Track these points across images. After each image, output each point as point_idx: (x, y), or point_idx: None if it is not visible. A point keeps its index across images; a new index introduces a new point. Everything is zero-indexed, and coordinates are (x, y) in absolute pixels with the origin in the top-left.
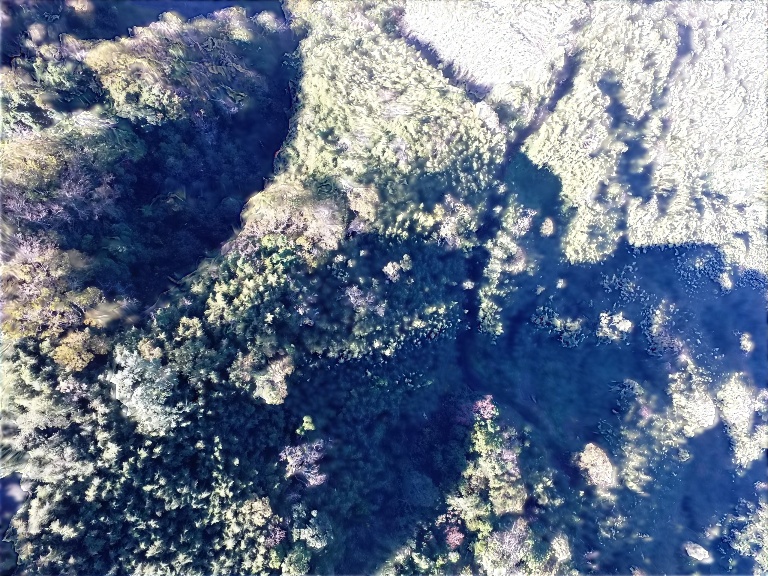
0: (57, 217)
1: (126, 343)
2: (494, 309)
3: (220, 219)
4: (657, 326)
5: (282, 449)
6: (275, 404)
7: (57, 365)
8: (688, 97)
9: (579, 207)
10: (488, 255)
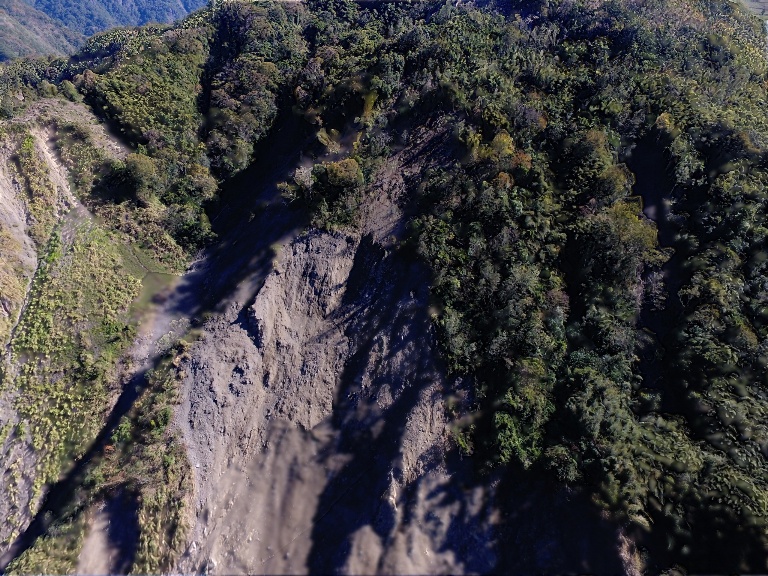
0: None
1: None
2: None
3: None
4: None
5: None
6: None
7: None
8: None
9: None
10: None
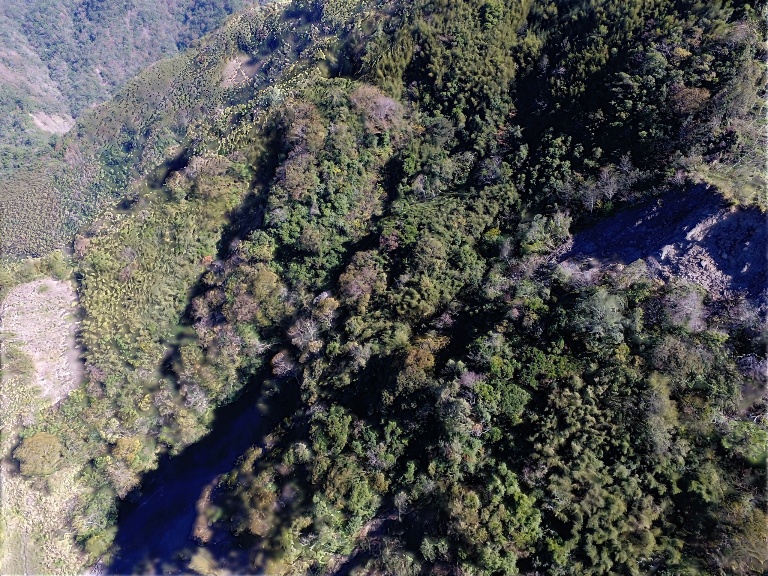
0: None
1: None
2: None
3: (248, 203)
4: None
5: None
6: None
7: None
8: None
9: None
10: None
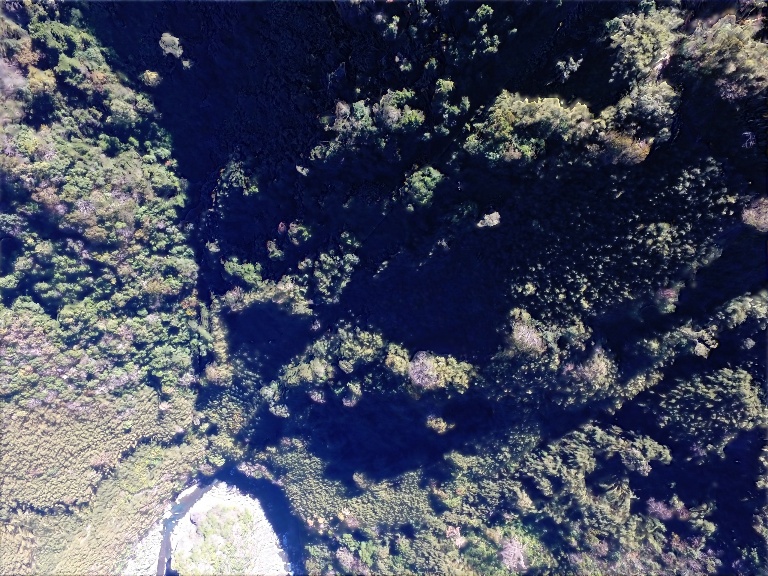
0: None
1: None
2: None
3: None
4: (598, 376)
5: None
6: None
7: None
8: (684, 567)
9: None
10: None
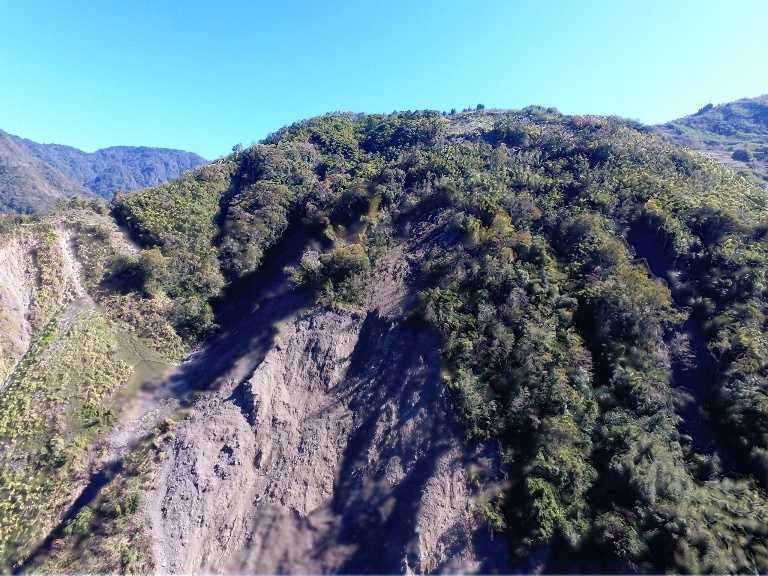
0: None
1: None
2: None
3: (235, 187)
4: None
5: None
6: None
7: None
8: None
9: None
10: None
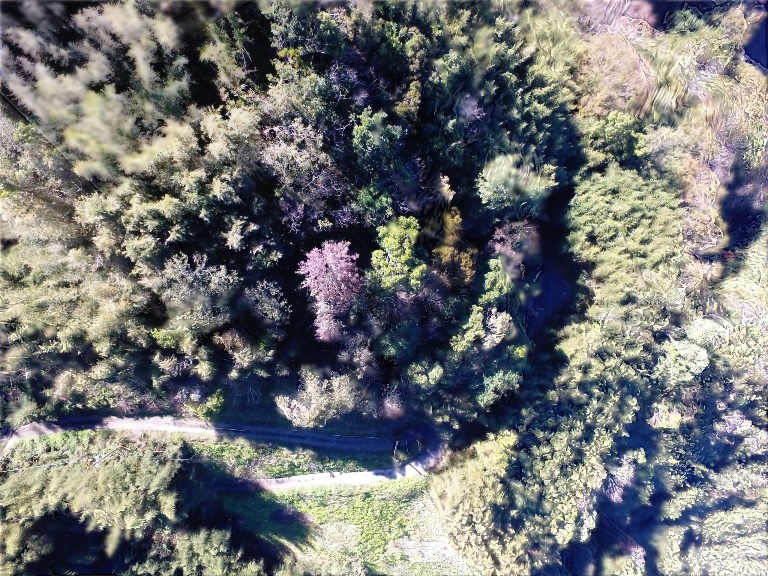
0: (718, 162)
1: (693, 296)
2: (691, 502)
3: None
4: None
5: (630, 454)
6: (639, 417)
7: (682, 266)
8: None
9: (765, 503)
10: (725, 468)
